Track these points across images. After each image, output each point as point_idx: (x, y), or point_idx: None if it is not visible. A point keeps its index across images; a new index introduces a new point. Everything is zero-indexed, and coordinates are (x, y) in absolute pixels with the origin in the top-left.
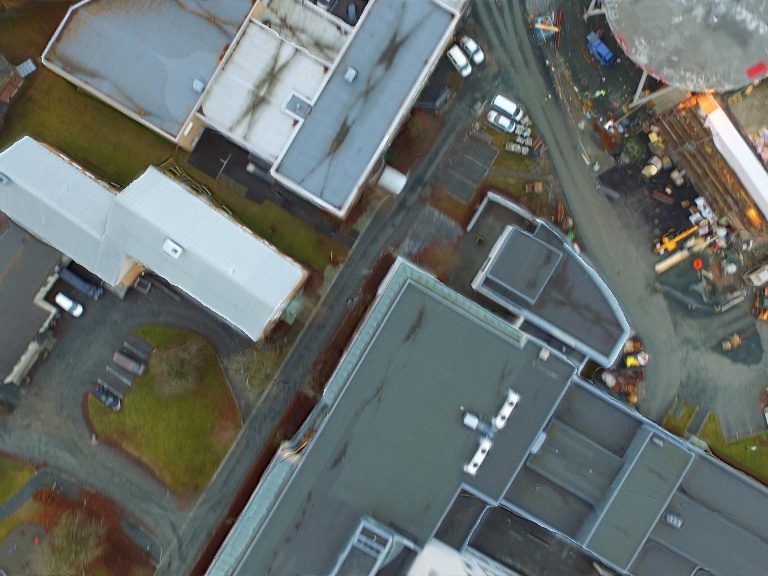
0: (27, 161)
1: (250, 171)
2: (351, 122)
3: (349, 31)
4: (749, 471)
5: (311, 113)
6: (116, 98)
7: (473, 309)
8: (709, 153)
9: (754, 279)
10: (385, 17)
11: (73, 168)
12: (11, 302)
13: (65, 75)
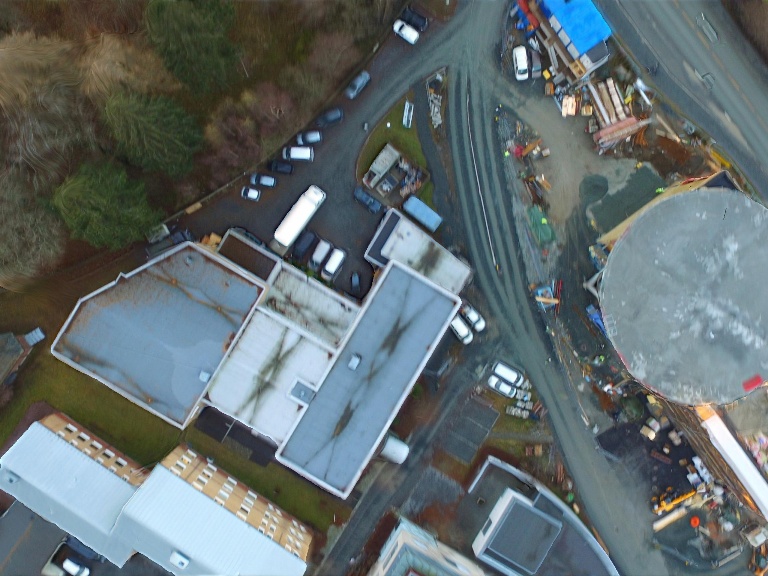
0: (36, 453)
1: (255, 434)
2: (355, 406)
3: (353, 309)
4: None
5: (315, 398)
6: (124, 387)
7: None
8: (706, 440)
9: (750, 540)
10: (388, 304)
11: (81, 453)
12: (19, 575)
13: (74, 365)
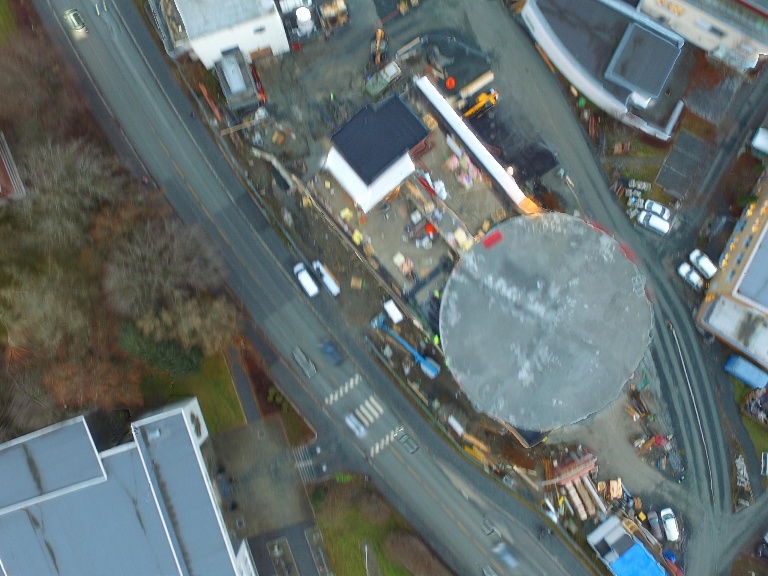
0: None
1: None
2: None
3: None
4: None
5: None
6: None
7: (718, 1)
8: None
9: None
10: None
11: None
12: None
13: None
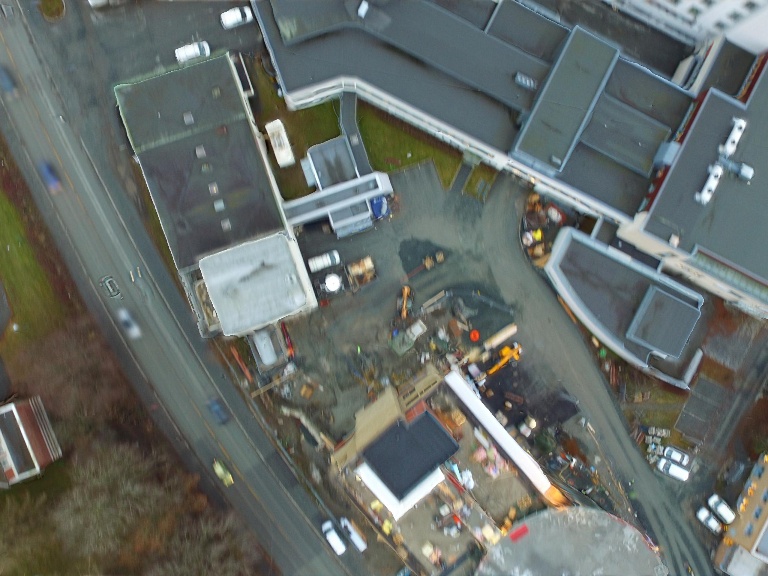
0: None
1: None
2: None
3: None
4: (413, 132)
5: None
6: None
7: (738, 279)
8: None
9: None
10: None
11: None
12: None
13: None
